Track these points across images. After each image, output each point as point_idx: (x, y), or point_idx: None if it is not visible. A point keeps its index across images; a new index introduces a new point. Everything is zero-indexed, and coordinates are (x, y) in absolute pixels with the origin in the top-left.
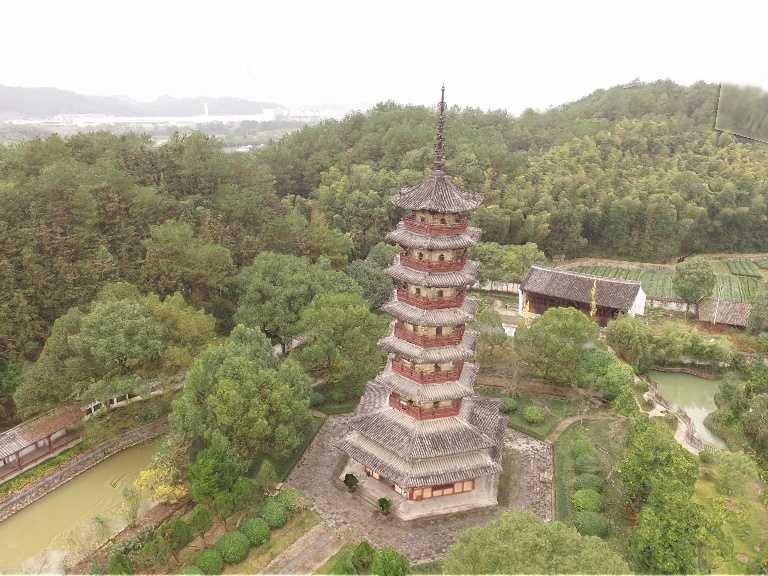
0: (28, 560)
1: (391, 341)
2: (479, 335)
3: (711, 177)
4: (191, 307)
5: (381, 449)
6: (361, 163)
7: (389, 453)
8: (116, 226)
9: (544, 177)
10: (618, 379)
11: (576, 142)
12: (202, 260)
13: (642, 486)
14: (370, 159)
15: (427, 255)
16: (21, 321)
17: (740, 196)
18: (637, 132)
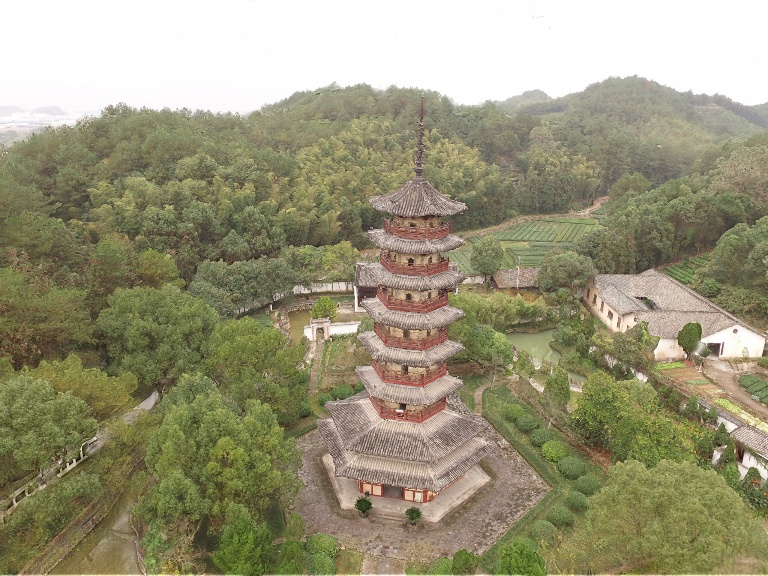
0: None
1: (384, 352)
2: None
3: (440, 168)
4: (95, 369)
5: (389, 463)
6: (125, 175)
7: (400, 464)
8: None
9: (312, 178)
10: (504, 347)
11: (324, 143)
12: (57, 310)
13: (599, 424)
14: (135, 170)
15: (419, 260)
16: None
17: (467, 183)
18: (373, 132)
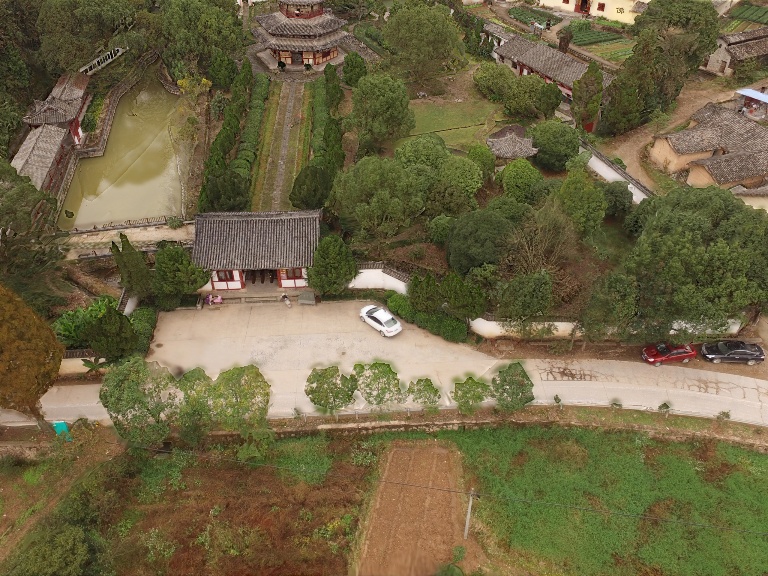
0: None
1: None
2: None
3: None
4: None
5: (294, 41)
6: None
7: (299, 41)
8: None
9: None
10: None
11: None
12: None
13: None
14: None
15: None
16: (2, 16)
17: None
18: None
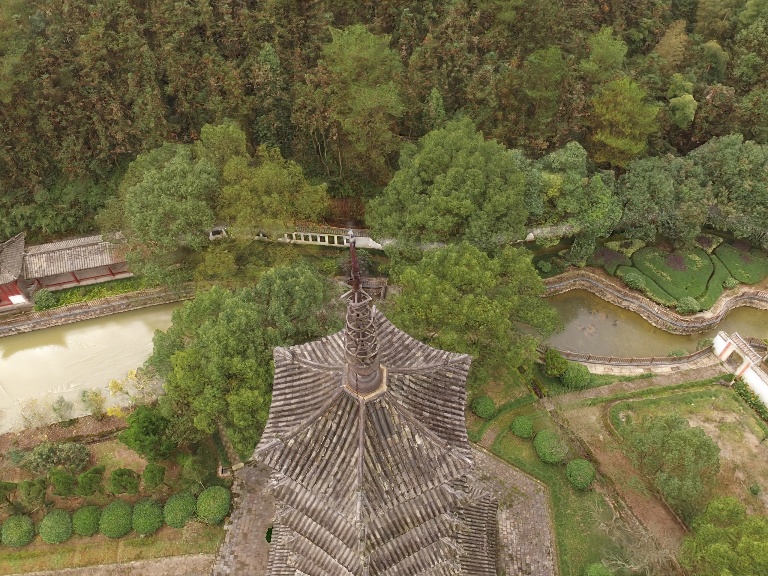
0: (8, 401)
1: None
2: (452, 573)
3: None
4: (275, 195)
5: None
6: None
7: None
8: (316, 6)
9: None
10: None
11: None
12: (361, 110)
13: None
14: None
15: None
16: None
17: None
18: None
